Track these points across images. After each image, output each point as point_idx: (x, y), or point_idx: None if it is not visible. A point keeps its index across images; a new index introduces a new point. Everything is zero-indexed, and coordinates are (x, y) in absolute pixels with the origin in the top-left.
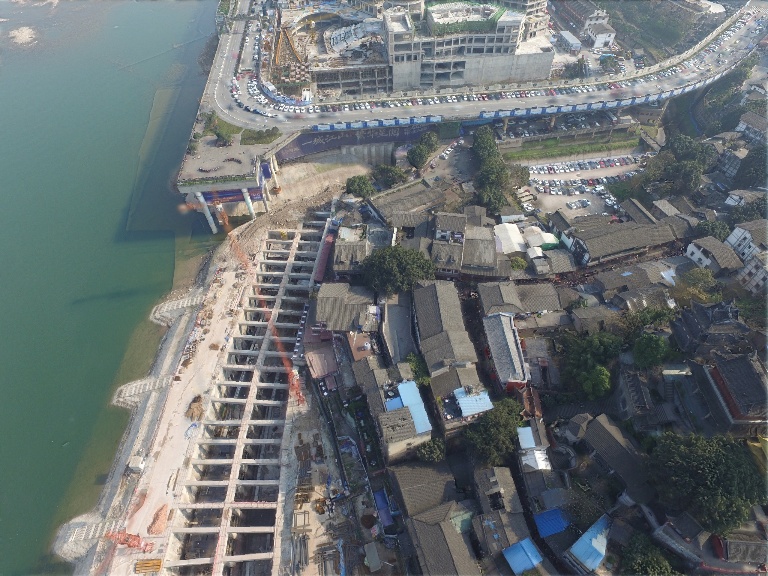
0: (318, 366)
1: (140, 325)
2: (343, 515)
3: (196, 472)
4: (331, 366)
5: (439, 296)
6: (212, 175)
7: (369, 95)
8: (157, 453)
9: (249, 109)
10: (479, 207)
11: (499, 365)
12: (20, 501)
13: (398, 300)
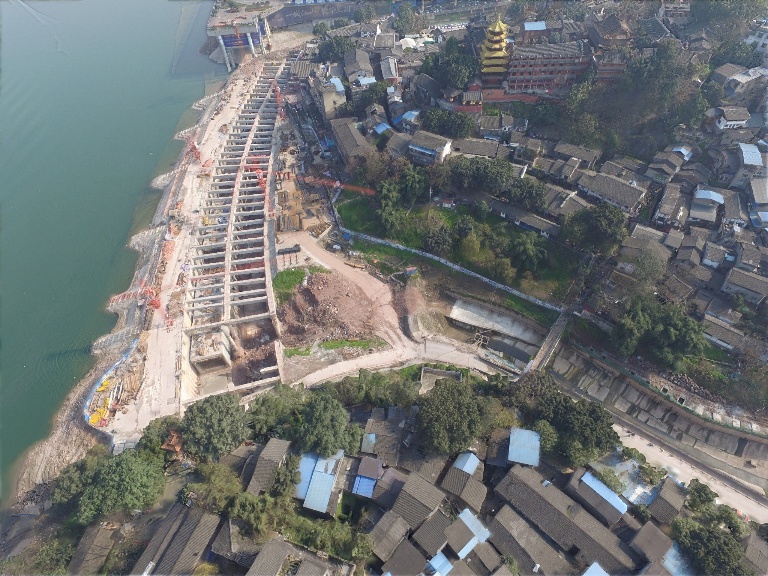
0: (292, 99)
1: (187, 110)
2: (304, 154)
3: (225, 156)
4: (299, 99)
5: (357, 52)
6: (228, 24)
7: None
8: (204, 143)
9: None
10: (391, 29)
11: (385, 74)
12: (130, 172)
13: (337, 65)
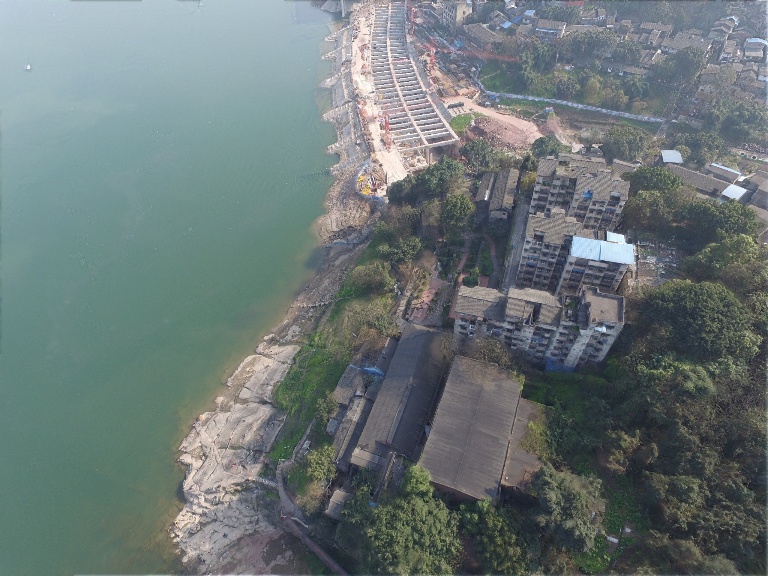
0: (419, 20)
1: (322, 42)
2: None
3: None
4: (424, 20)
5: None
6: None
7: None
8: None
9: None
10: None
11: None
12: (298, 80)
13: None
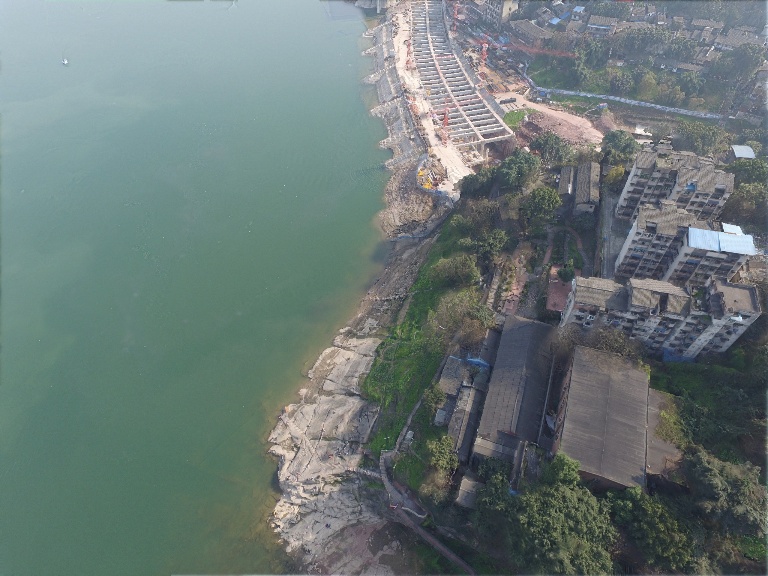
0: (461, 17)
1: (360, 38)
2: None
3: None
4: (466, 16)
5: None
6: None
7: None
8: None
9: None
10: None
11: None
12: None
13: None
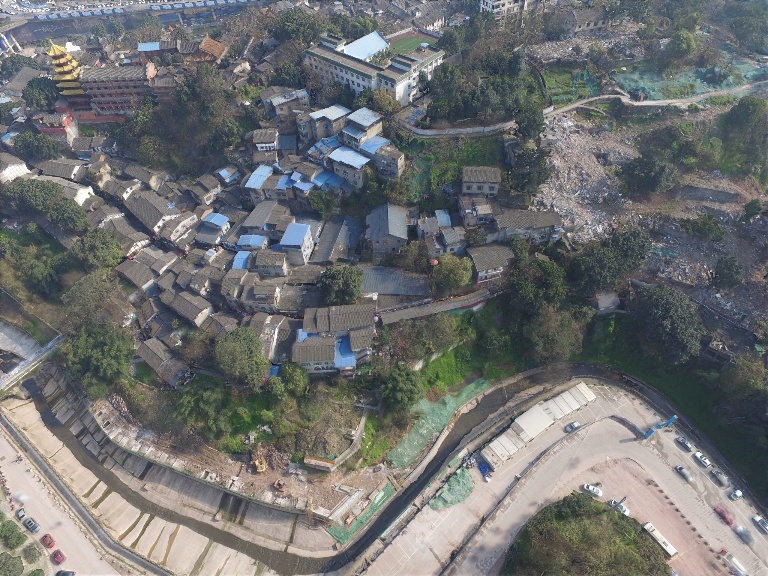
0: None
1: None
2: None
3: None
4: None
5: (23, 71)
6: None
7: (86, 1)
8: None
9: (2, 11)
10: None
11: None
12: None
13: None
